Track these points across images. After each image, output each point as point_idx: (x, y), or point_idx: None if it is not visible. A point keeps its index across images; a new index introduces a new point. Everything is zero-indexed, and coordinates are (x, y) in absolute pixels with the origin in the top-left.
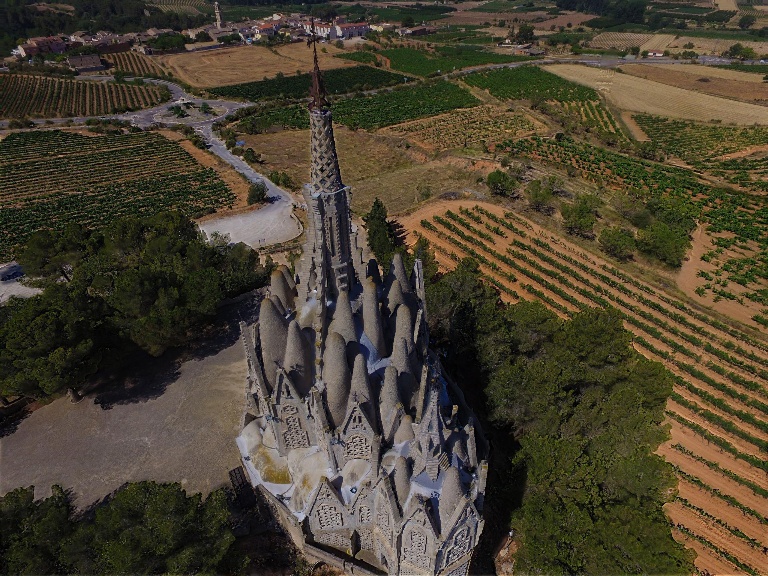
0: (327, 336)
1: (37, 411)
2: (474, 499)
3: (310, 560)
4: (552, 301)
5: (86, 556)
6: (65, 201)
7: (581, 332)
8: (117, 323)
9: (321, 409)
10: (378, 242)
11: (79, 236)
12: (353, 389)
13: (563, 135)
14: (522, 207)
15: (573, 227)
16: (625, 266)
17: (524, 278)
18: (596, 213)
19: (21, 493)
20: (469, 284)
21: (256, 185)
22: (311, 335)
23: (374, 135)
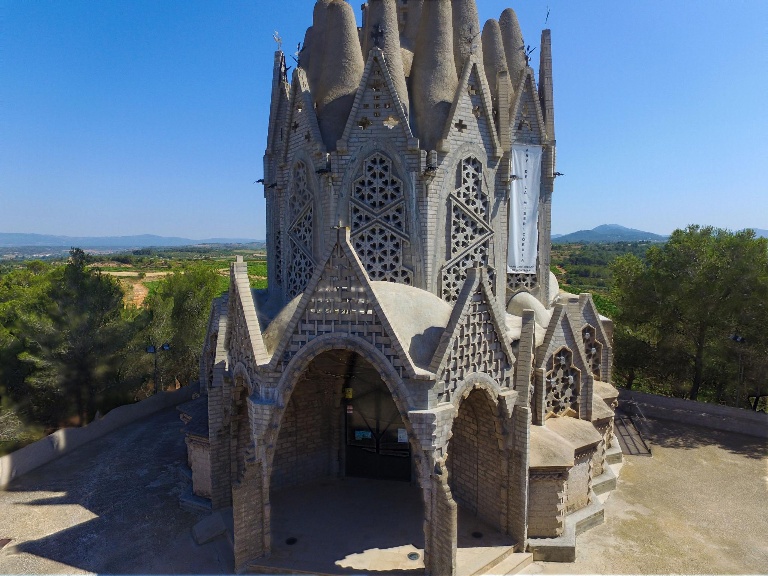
0: None
1: None
2: None
3: None
4: None
5: None
6: None
7: None
8: None
9: None
10: None
11: None
12: None
13: None
14: None
15: None
16: None
17: None
18: None
19: None
20: None
21: None
22: None
23: None
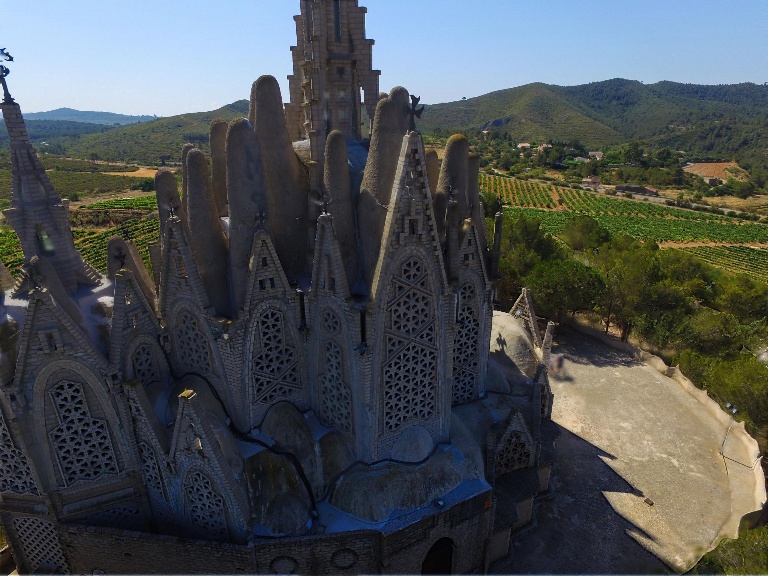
0: None
1: None
2: None
3: None
4: None
5: None
6: None
7: None
8: None
9: None
10: None
11: None
12: None
13: None
14: None
15: None
16: None
17: None
18: None
19: None
20: None
21: None
22: None
23: None
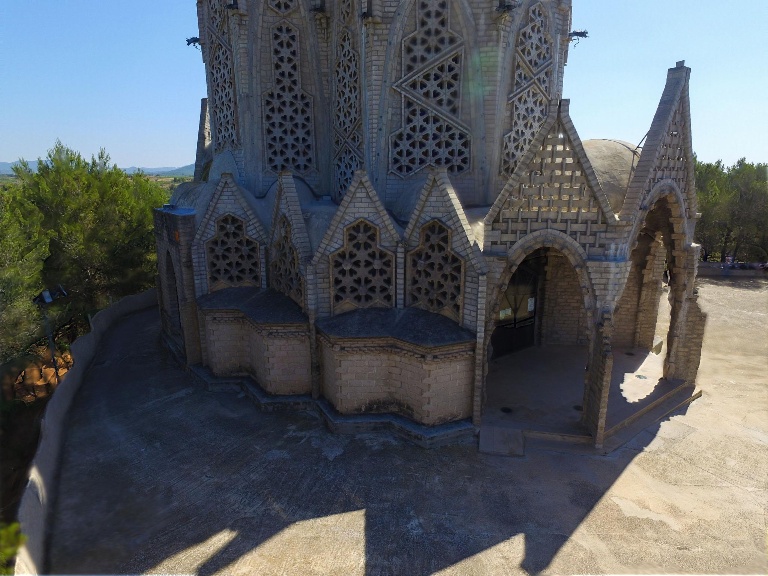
0: None
1: None
2: None
3: None
4: None
5: None
6: None
7: None
8: None
9: None
10: None
11: None
12: None
13: None
14: None
15: None
16: None
17: None
18: None
19: None
20: None
21: None
22: None
23: None
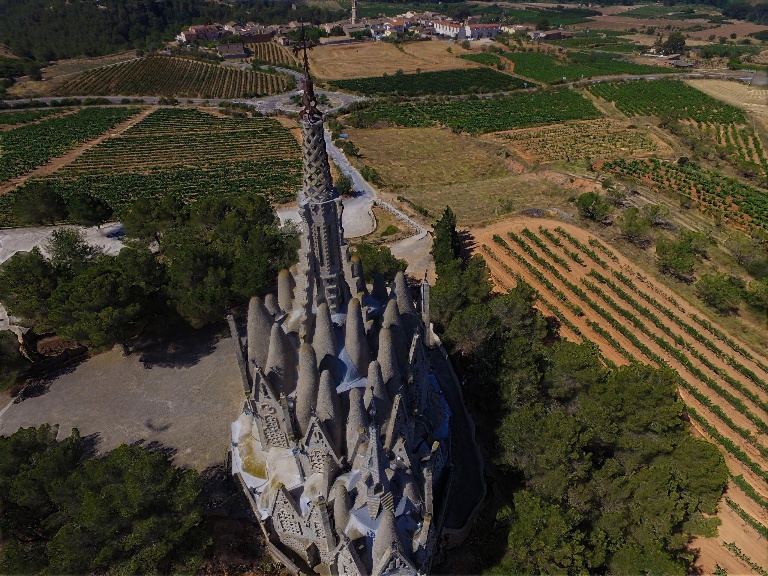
0: (311, 344)
1: (94, 358)
2: (416, 549)
3: (275, 558)
4: (618, 345)
5: (74, 499)
6: (182, 173)
7: (624, 389)
8: (169, 292)
9: (287, 416)
10: (440, 251)
11: (172, 207)
12: (318, 403)
13: (688, 160)
14: (612, 235)
15: (668, 266)
16: (724, 320)
17: (593, 314)
18: (704, 253)
19: (38, 430)
20: (517, 311)
21: (343, 178)
22: (297, 340)
23: (476, 140)
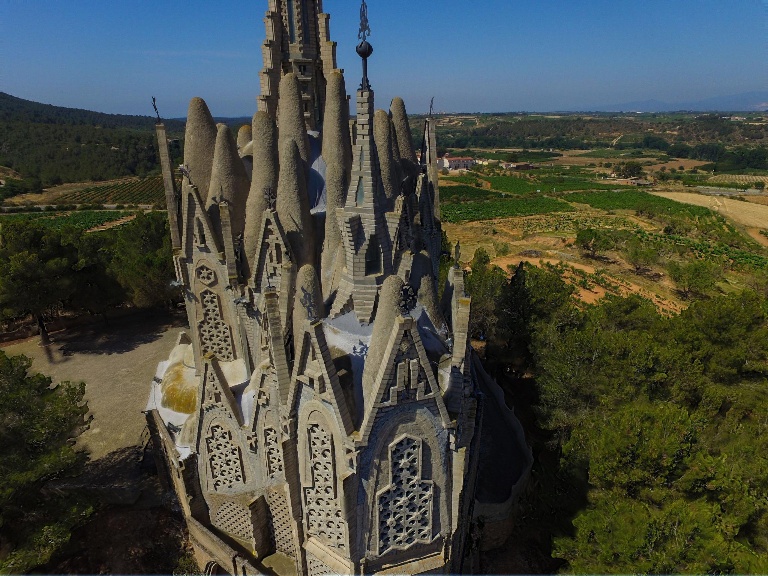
0: None
1: (1, 348)
2: (444, 389)
3: (200, 561)
4: None
5: None
6: None
7: None
8: (111, 265)
9: (229, 240)
10: None
11: None
12: (278, 206)
13: (673, 229)
14: (618, 270)
15: (686, 291)
16: None
17: None
18: (718, 288)
19: None
20: None
21: None
22: None
23: (462, 226)
